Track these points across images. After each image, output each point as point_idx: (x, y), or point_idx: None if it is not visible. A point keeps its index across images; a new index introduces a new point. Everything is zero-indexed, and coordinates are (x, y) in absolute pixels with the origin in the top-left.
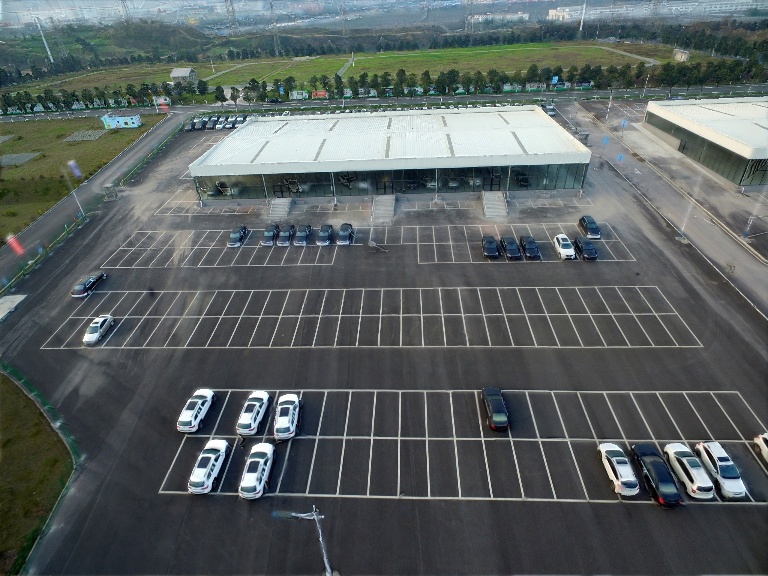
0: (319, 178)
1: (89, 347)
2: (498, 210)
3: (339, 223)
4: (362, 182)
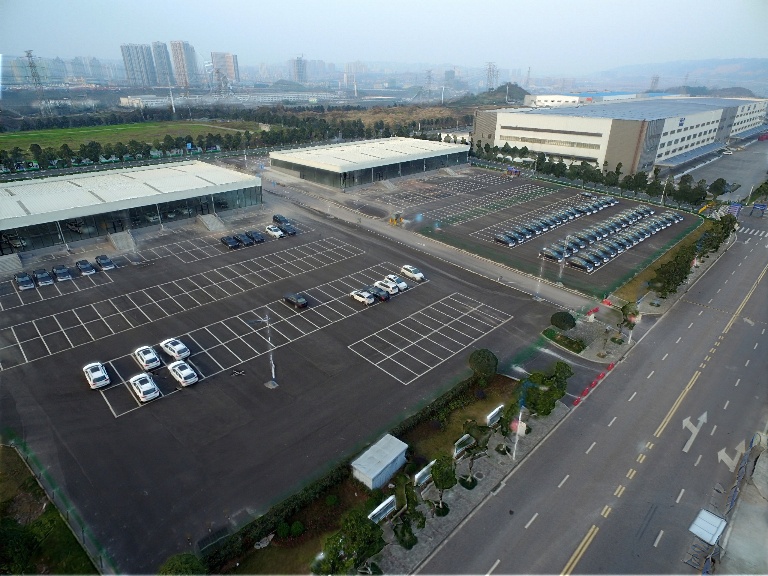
0: (44, 229)
1: None
2: (216, 225)
3: (88, 259)
4: (91, 225)
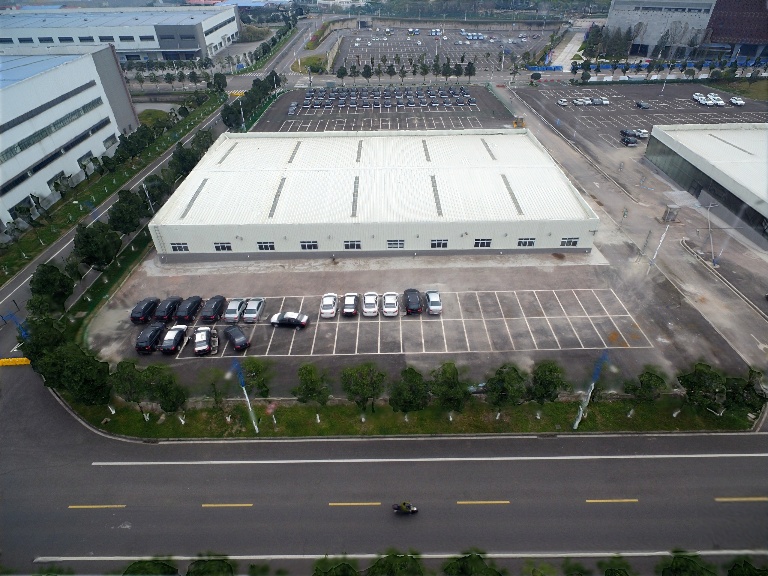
0: None
1: None
2: None
3: None
4: None
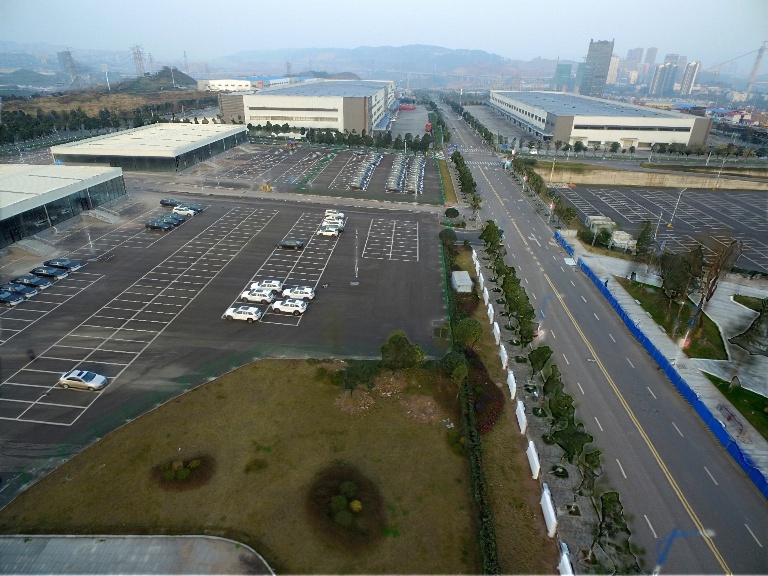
0: None
1: (107, 386)
2: (111, 218)
3: (28, 270)
4: None
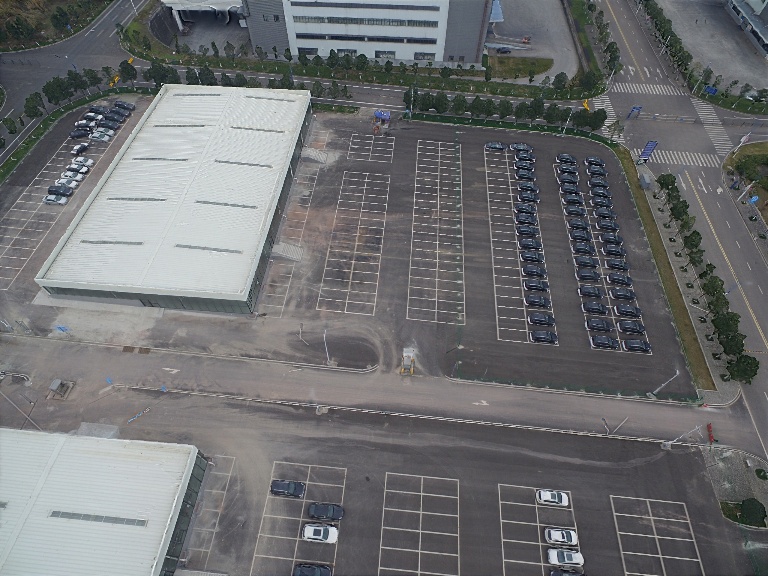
0: None
1: None
2: None
3: None
4: None
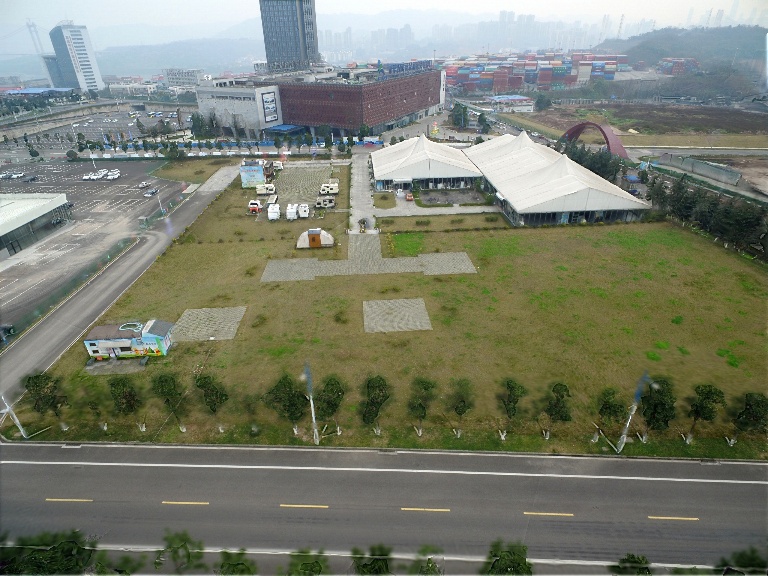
0: None
1: None
2: None
3: None
4: None
